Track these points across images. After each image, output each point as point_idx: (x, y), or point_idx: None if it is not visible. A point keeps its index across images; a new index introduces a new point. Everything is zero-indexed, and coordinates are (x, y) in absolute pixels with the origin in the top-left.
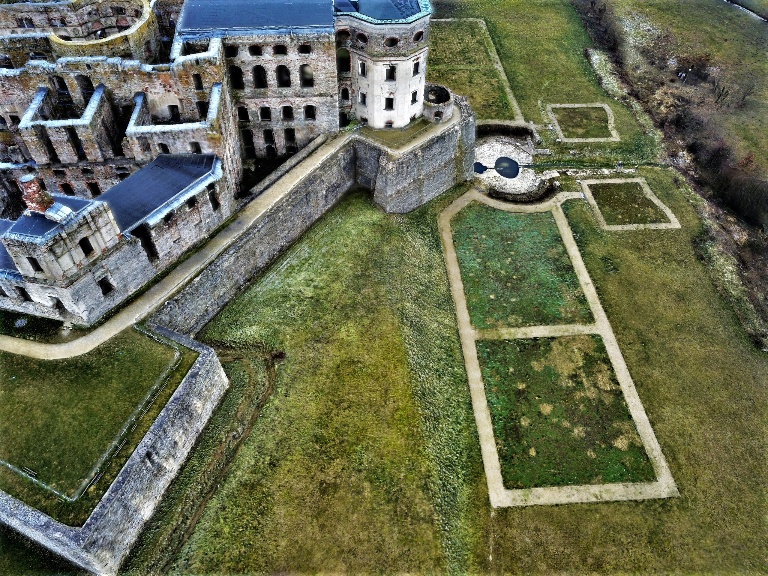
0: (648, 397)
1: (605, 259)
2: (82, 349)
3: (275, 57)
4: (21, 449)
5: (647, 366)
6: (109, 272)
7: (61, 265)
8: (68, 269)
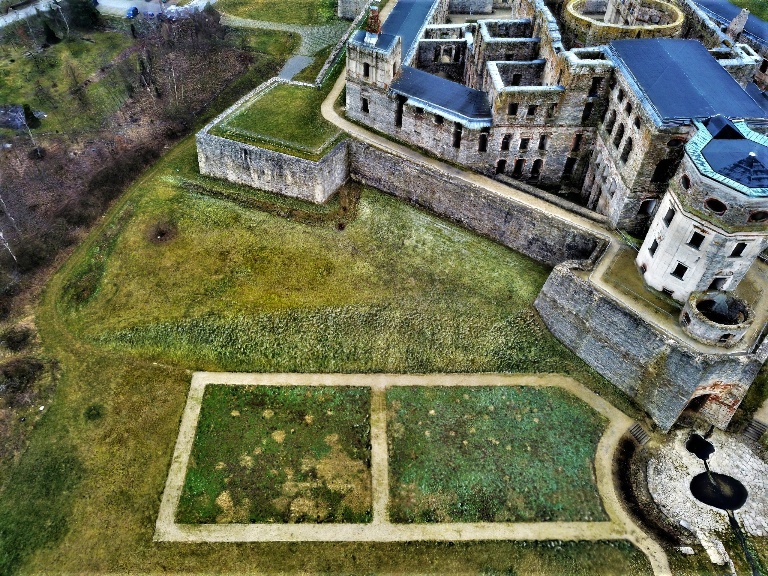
0: (274, 552)
1: (512, 575)
2: (327, 116)
3: (624, 113)
4: (260, 108)
5: (317, 568)
6: (370, 99)
7: (350, 65)
8: (352, 71)
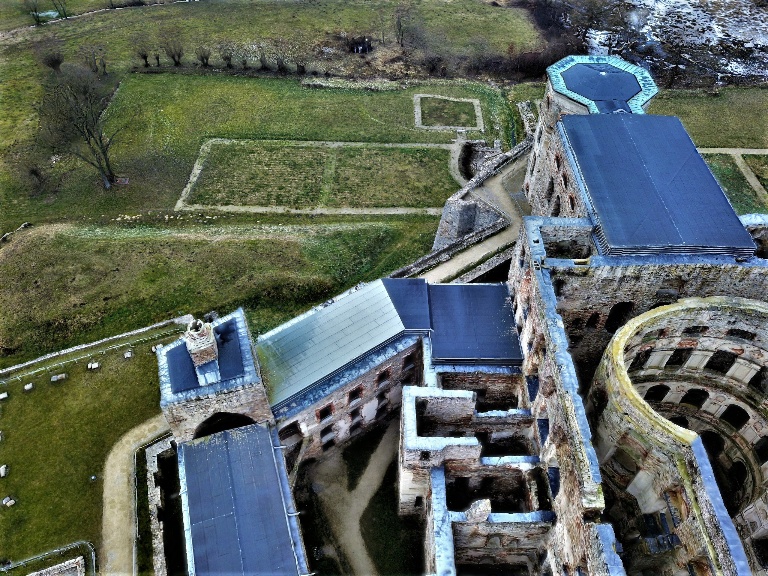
0: None
1: None
2: None
3: None
4: None
5: (761, 140)
6: None
7: None
8: None
